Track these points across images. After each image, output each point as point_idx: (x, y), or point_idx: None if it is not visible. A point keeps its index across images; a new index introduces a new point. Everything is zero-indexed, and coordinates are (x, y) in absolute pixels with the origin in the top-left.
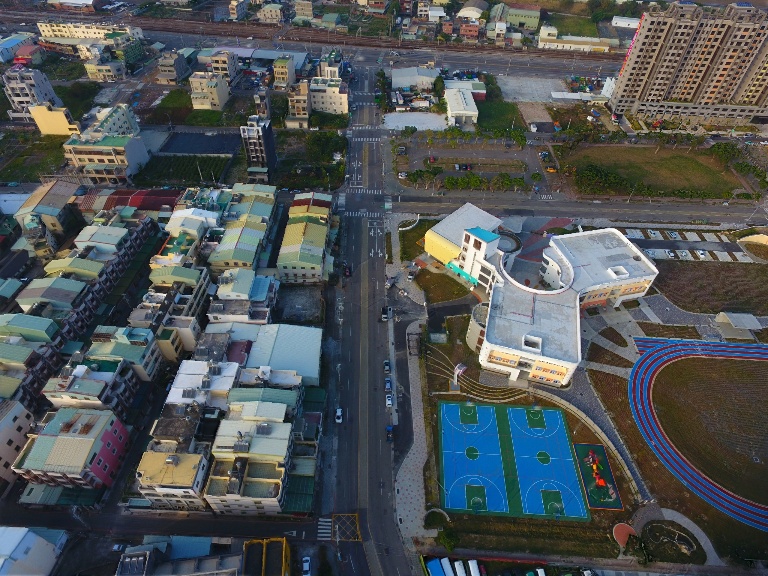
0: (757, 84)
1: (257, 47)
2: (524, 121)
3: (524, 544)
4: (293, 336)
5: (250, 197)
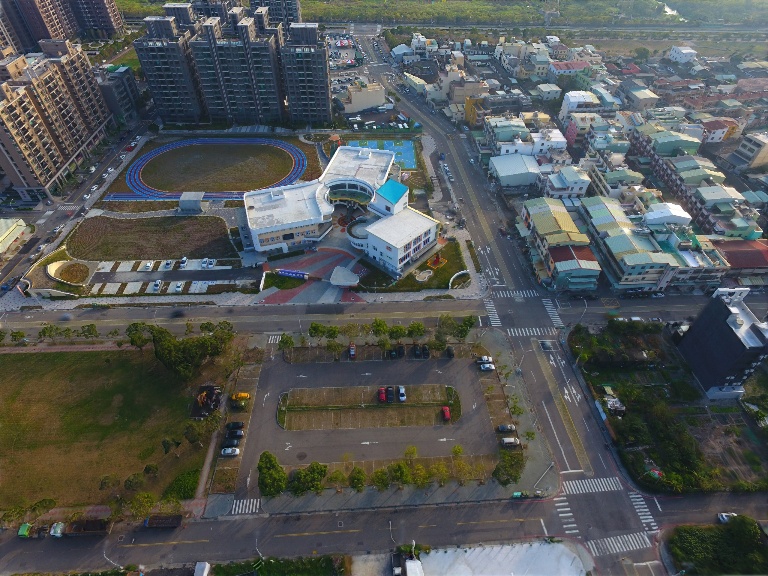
0: None
1: None
2: None
3: None
4: (516, 169)
5: None
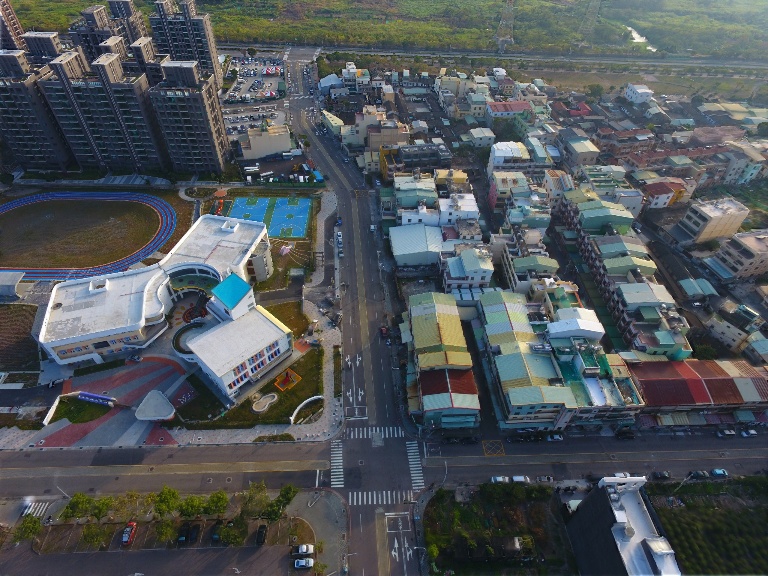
0: None
1: None
2: None
3: (274, 191)
4: (415, 246)
5: None
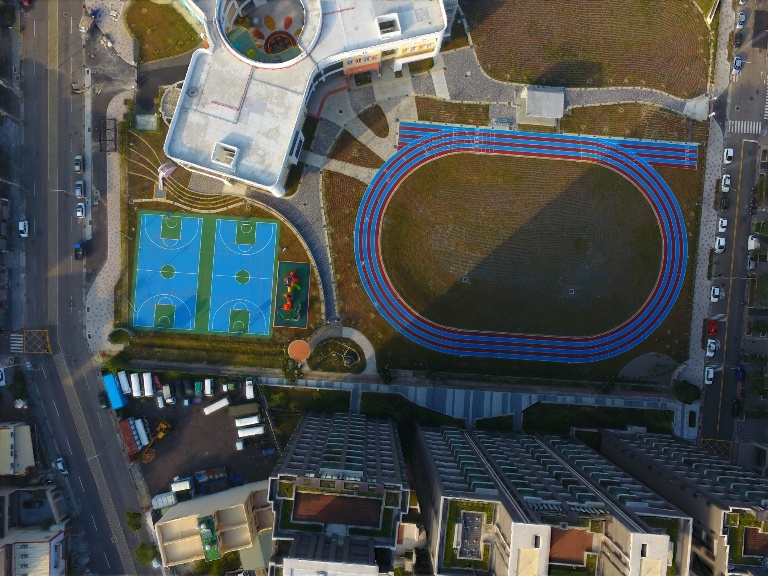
0: None
1: None
2: None
3: (203, 357)
4: None
5: None
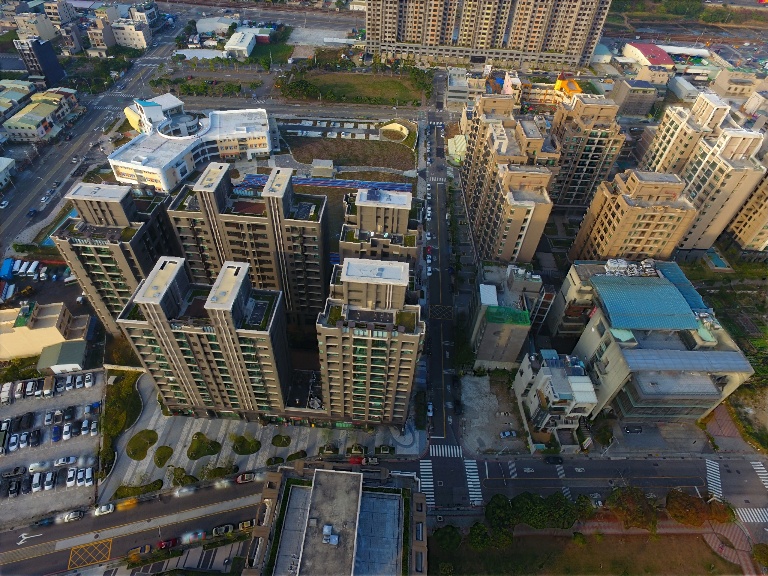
0: (467, 29)
1: (98, 1)
2: (290, 57)
3: None
4: None
5: (9, 88)
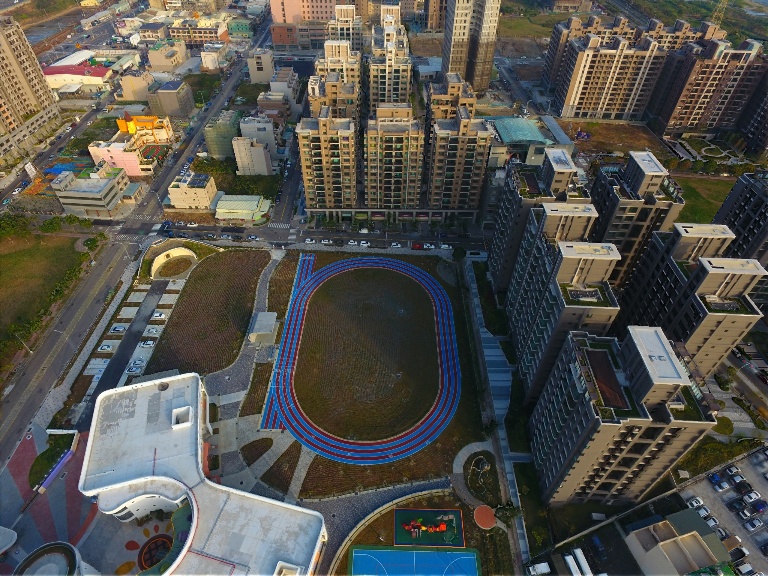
0: None
1: None
2: None
3: None
4: None
5: None
